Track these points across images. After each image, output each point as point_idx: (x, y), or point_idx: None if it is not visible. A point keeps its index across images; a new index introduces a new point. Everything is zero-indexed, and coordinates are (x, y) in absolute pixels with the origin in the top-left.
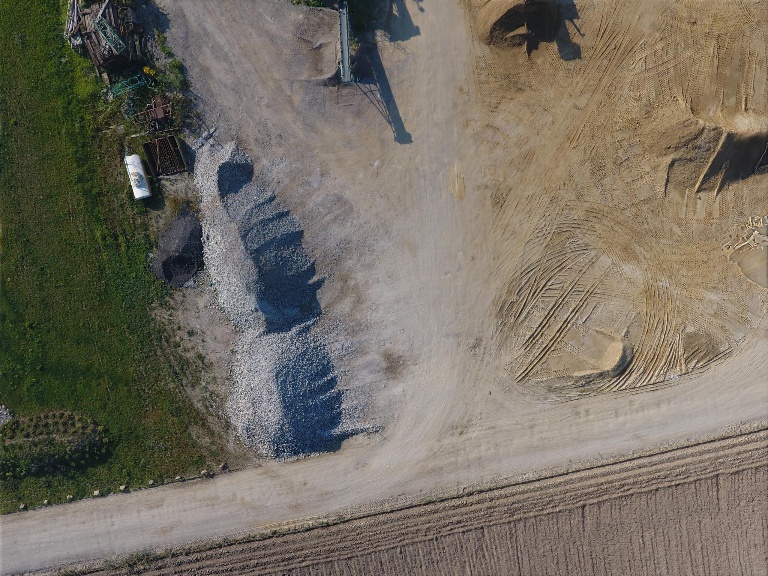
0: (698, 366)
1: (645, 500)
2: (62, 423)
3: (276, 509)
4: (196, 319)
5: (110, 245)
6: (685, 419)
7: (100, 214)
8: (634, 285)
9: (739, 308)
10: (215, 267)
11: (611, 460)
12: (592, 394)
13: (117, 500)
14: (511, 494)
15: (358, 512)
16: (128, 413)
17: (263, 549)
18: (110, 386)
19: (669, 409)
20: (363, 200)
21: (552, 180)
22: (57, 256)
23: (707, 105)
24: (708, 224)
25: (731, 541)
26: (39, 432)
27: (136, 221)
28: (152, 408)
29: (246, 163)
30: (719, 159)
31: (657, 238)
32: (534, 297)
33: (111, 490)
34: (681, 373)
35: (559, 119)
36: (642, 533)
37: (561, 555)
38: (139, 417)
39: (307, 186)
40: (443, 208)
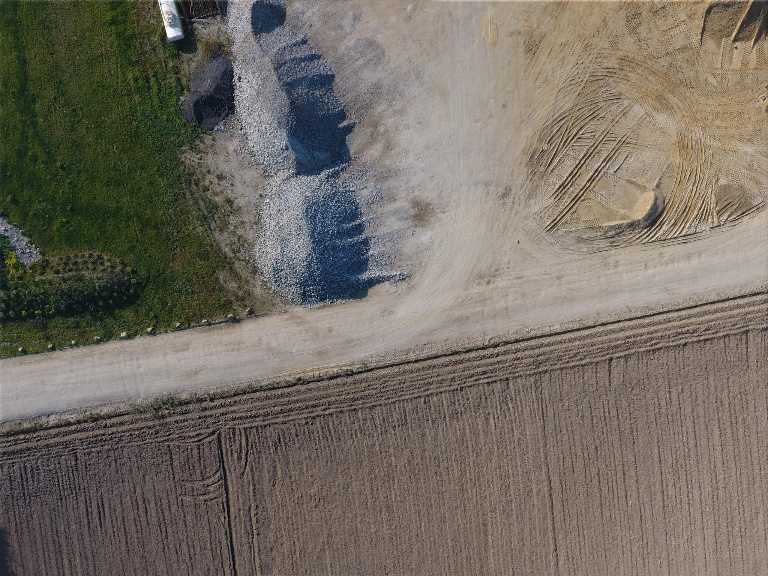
0: (730, 219)
1: (673, 354)
2: (91, 262)
3: (301, 355)
4: (226, 163)
5: (142, 87)
6: (716, 273)
7: (133, 56)
8: (667, 135)
9: None
10: (246, 108)
11: (639, 313)
12: (622, 245)
13: (144, 342)
14: (537, 346)
15: (383, 361)
16: (156, 256)
17: (287, 396)
18: (139, 228)
19: (700, 262)
20: (395, 44)
21: (586, 27)
22: (89, 98)
23: None
24: (744, 74)
25: (759, 399)
26: (69, 268)
27: (168, 65)
28: (180, 251)
29: (279, 5)
30: (758, 4)
31: (692, 88)
32: (565, 146)
33: (138, 332)
34: (713, 226)
35: None
36: (669, 388)
37: (586, 409)
38: (167, 260)
39: (339, 30)
40: (475, 54)
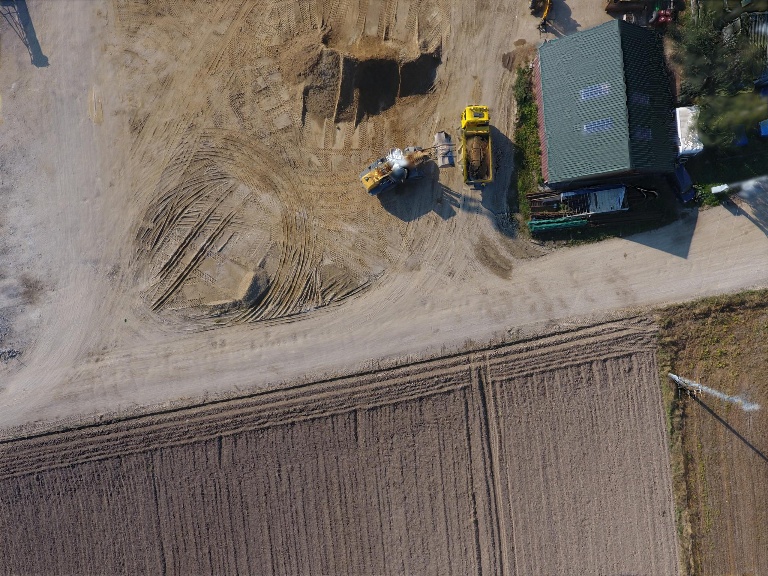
0: (335, 299)
1: (281, 434)
2: None
3: None
4: None
5: None
6: (322, 353)
7: None
8: (271, 215)
9: (378, 241)
10: None
11: (247, 392)
12: (228, 324)
13: None
14: (148, 424)
15: None
16: None
17: None
18: None
19: (305, 342)
20: (0, 123)
21: (190, 107)
22: None
23: (347, 34)
24: (347, 155)
25: (369, 478)
26: None
27: None
28: None
29: None
30: (347, 87)
31: (295, 168)
32: (170, 225)
33: None
34: (317, 306)
35: (198, 45)
36: (279, 467)
37: (198, 487)
38: None
39: None
40: (81, 133)
